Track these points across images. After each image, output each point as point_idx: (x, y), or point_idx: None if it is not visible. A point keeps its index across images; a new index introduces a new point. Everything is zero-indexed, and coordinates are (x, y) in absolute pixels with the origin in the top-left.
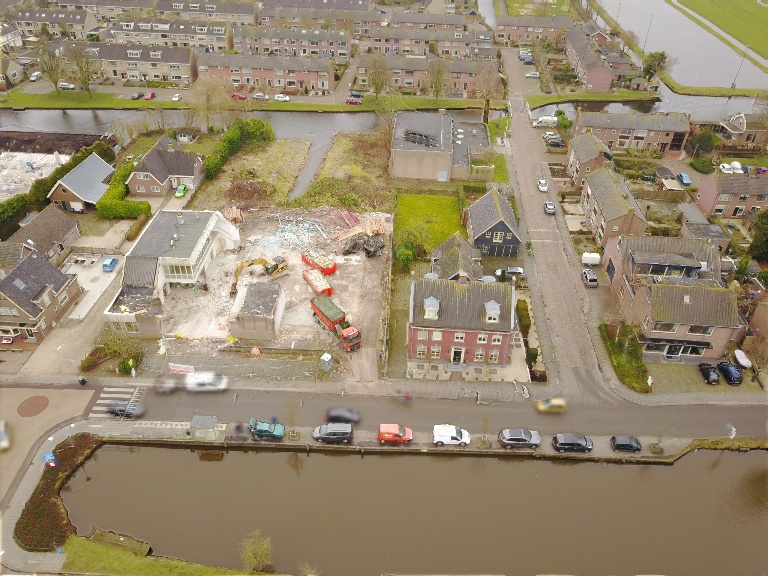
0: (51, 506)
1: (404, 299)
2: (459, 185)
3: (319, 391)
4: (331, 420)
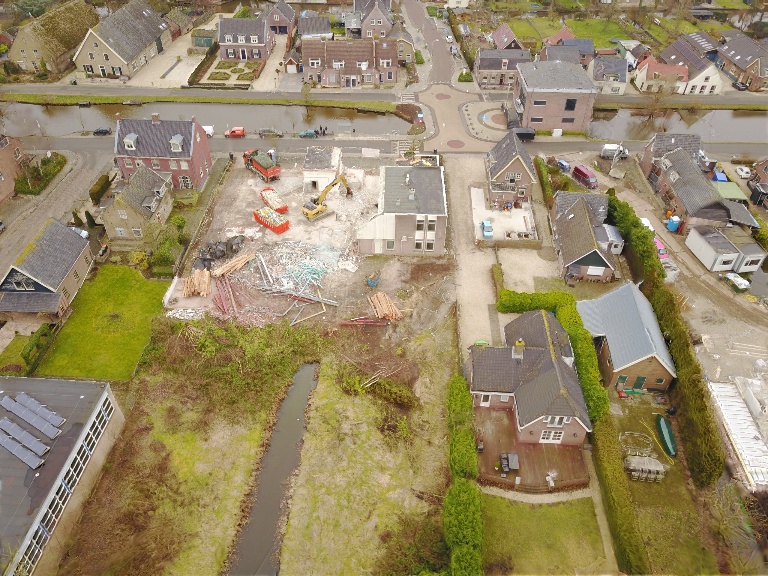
0: (410, 114)
1: (195, 215)
2: (27, 352)
3: (278, 152)
4: (272, 141)
